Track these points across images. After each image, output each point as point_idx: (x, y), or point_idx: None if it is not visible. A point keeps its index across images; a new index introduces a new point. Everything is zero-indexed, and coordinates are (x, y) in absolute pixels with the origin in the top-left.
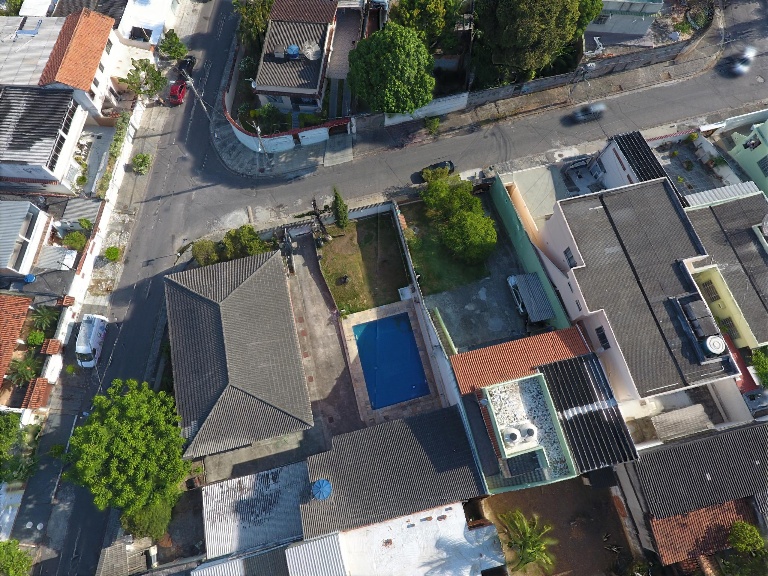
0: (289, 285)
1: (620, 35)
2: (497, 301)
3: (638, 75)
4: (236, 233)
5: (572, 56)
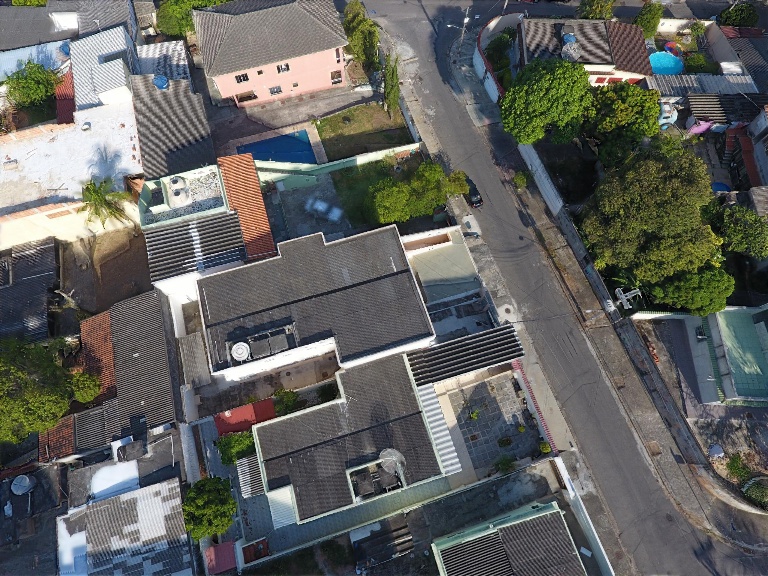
0: (342, 86)
1: (694, 373)
2: (327, 232)
3: (647, 411)
4: (370, 25)
5: (637, 306)
